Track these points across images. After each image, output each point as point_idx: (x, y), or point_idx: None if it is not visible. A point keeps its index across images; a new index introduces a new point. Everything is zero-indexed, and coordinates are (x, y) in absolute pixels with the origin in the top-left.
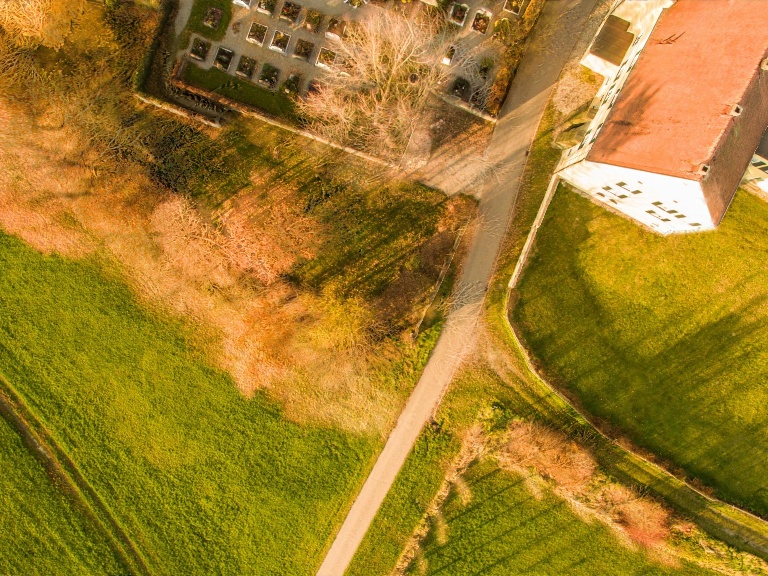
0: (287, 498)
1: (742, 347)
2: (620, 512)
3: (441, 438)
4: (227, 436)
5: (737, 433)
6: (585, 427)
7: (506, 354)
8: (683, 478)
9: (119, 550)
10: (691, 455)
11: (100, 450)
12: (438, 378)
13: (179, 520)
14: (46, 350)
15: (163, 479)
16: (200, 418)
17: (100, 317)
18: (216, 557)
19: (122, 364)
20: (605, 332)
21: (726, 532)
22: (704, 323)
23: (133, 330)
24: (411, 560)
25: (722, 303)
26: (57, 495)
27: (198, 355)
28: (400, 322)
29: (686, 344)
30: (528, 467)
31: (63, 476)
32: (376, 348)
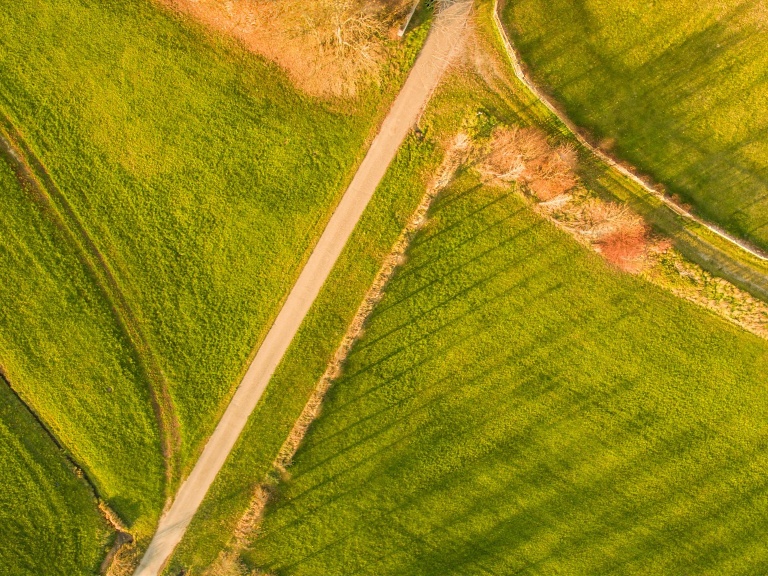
0: (265, 210)
1: (726, 60)
2: (598, 233)
3: (424, 147)
4: (206, 142)
5: (717, 151)
6: (568, 139)
7: (493, 58)
8: (662, 190)
9: (88, 263)
10: (671, 172)
11: (74, 155)
12: (424, 81)
13: (152, 232)
14: (22, 44)
15: (138, 188)
16: (179, 122)
17: (80, 10)
18: (189, 273)
19: (101, 61)
20: (593, 39)
21: (701, 257)
22: (690, 33)
23: (114, 25)
24: (388, 279)
25: (709, 11)
26: (26, 201)
27: (180, 54)
28: (389, 17)
29: (671, 55)
30: (510, 182)
31: (34, 181)
32: (363, 48)
